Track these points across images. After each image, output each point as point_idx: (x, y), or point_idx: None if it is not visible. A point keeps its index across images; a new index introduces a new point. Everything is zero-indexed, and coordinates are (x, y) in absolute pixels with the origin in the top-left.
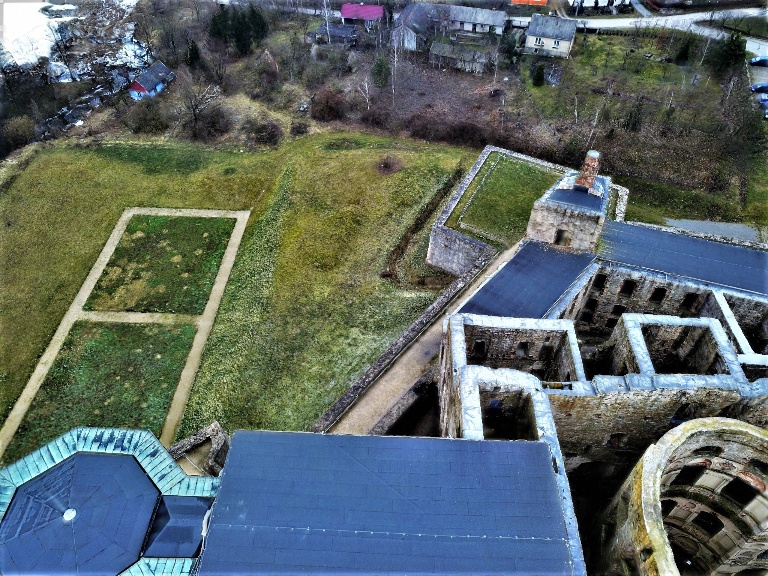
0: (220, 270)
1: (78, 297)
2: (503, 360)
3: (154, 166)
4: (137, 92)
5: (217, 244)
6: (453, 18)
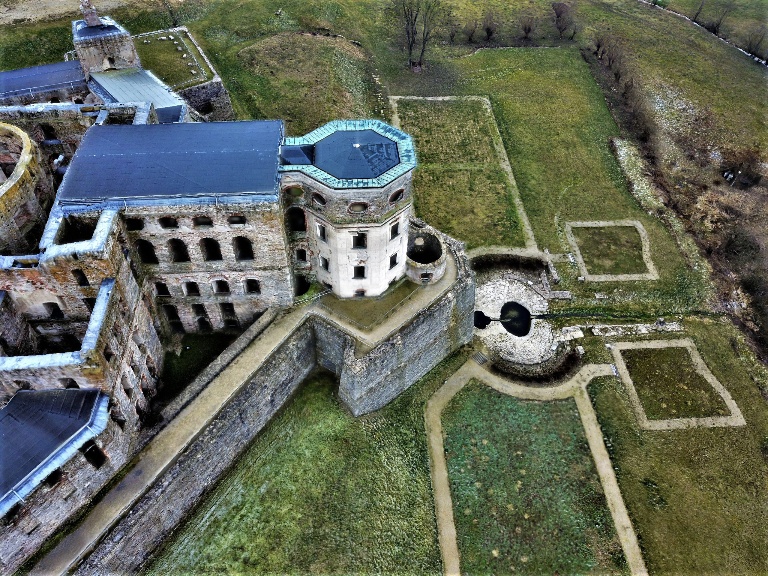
0: None
1: None
2: None
3: None
4: None
5: None
6: None
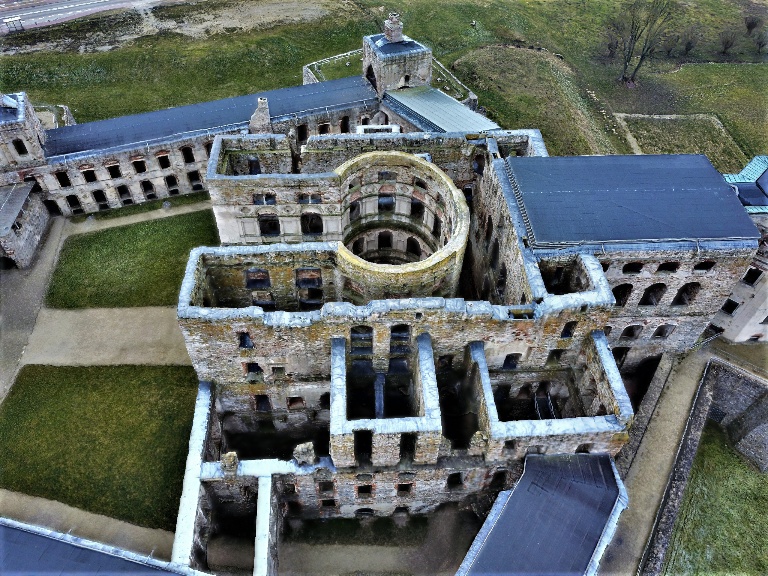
0: None
1: None
2: None
3: None
4: None
5: None
6: None
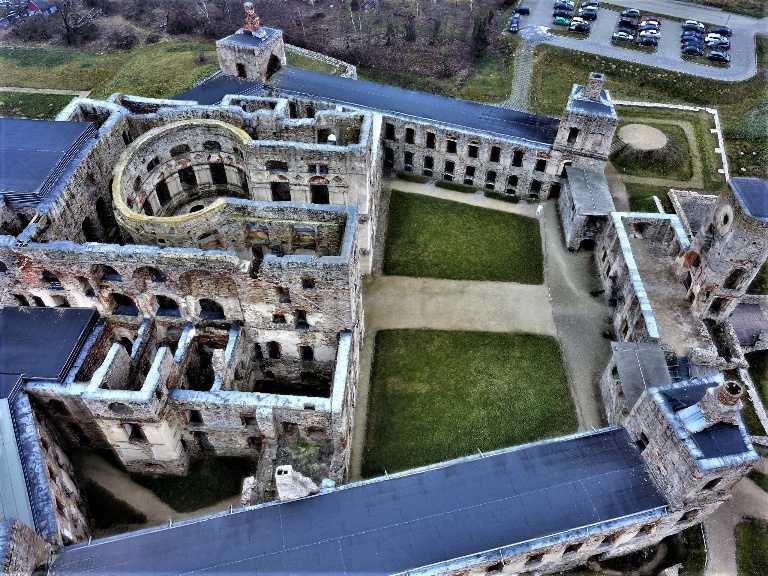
0: None
1: None
2: None
3: (29, 61)
4: (33, 12)
5: (57, 111)
6: None
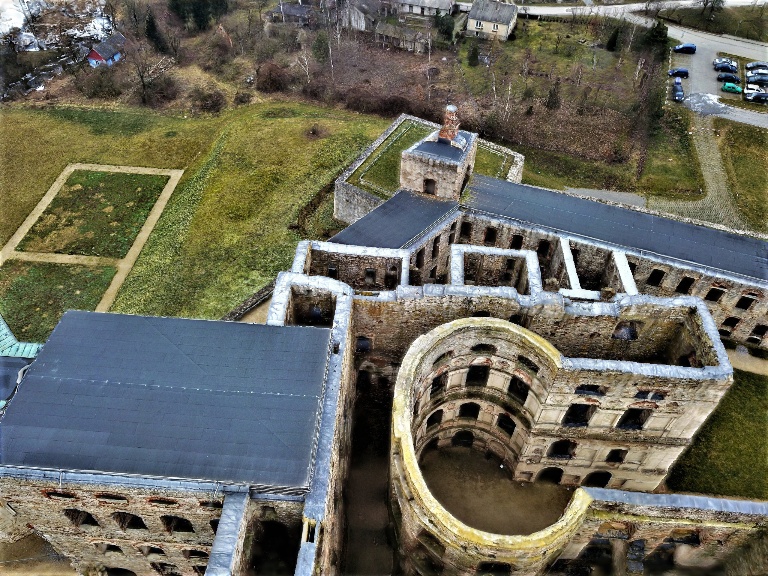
0: (147, 220)
1: (12, 239)
2: (354, 287)
3: (101, 127)
4: (95, 60)
5: (148, 198)
6: (402, 1)
